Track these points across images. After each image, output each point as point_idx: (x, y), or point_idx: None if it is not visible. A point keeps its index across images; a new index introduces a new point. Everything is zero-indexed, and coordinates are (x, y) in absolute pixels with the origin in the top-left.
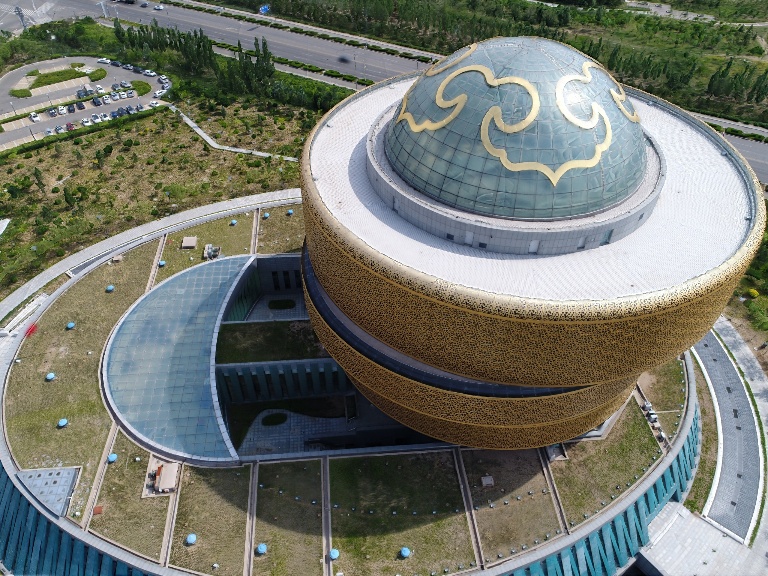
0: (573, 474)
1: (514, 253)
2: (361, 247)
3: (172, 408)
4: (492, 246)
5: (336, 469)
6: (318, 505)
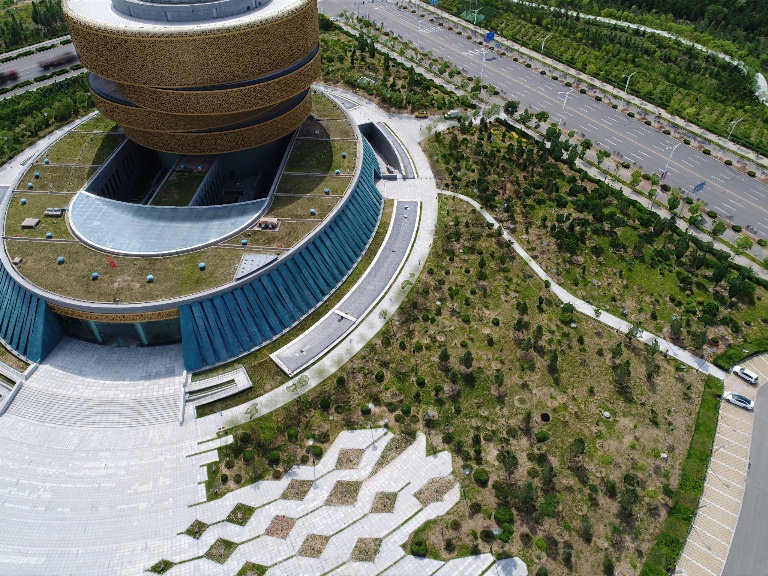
0: (323, 114)
1: (267, 2)
2: (243, 22)
3: (217, 221)
4: (262, 2)
5: (290, 170)
6: (309, 176)
